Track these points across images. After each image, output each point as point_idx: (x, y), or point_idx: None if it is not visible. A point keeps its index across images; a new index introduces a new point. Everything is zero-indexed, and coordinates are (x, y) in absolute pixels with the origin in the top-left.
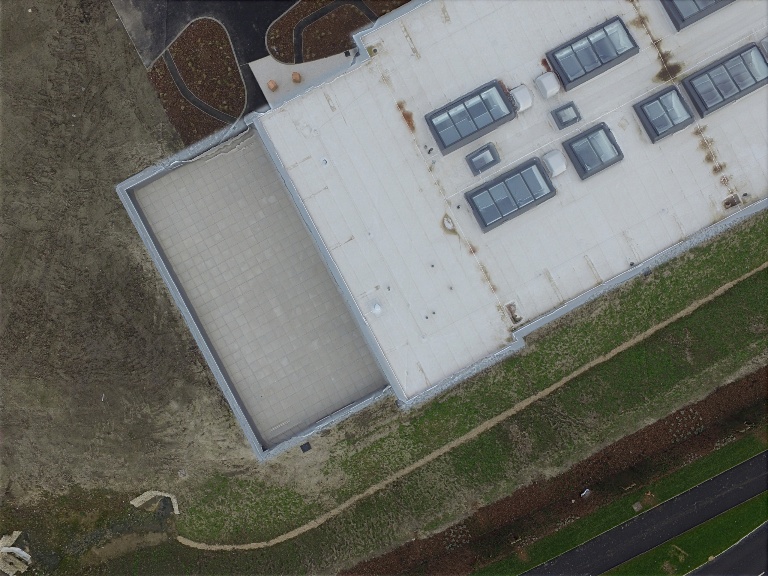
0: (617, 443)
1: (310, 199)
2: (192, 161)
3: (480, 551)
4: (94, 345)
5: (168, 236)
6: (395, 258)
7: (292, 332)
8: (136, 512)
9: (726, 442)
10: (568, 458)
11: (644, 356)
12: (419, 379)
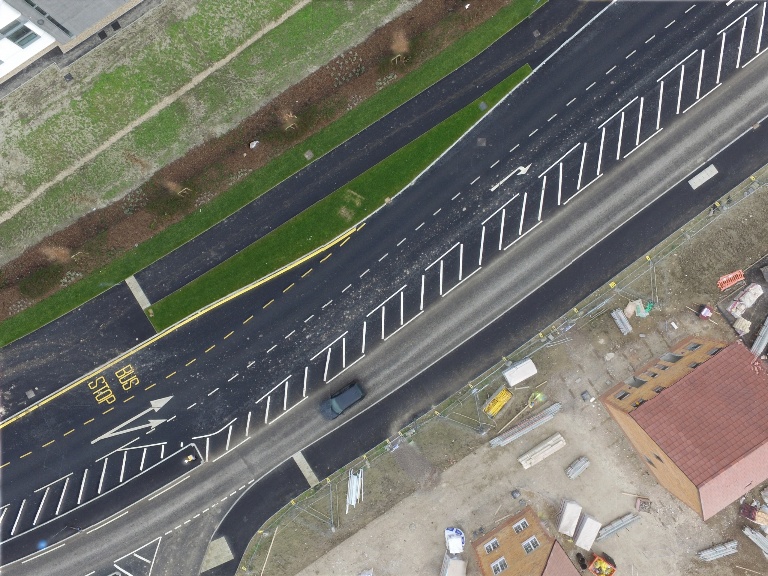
0: (283, 94)
1: None
2: None
3: (157, 212)
4: None
5: None
6: None
7: None
8: None
9: (388, 80)
10: (237, 114)
11: (311, 14)
12: None
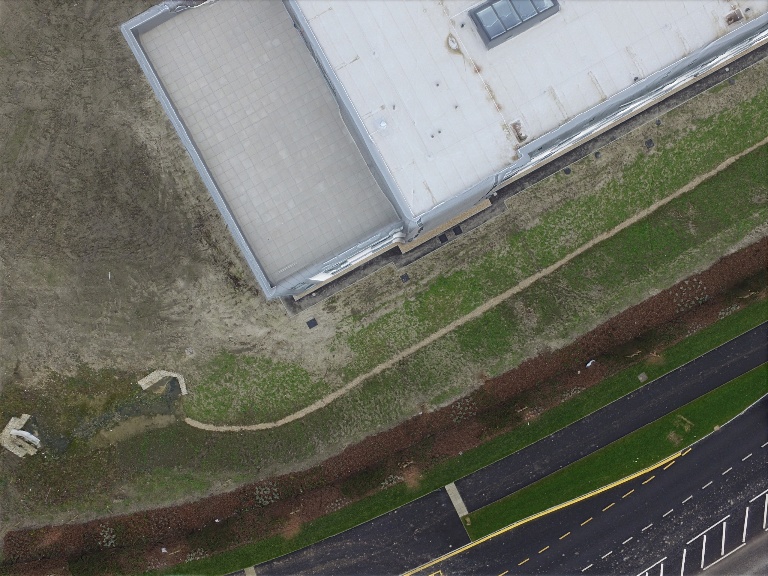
0: (622, 314)
1: (315, 20)
2: (196, 7)
3: (487, 423)
4: (100, 224)
5: (173, 80)
6: (400, 77)
7: (298, 174)
8: (144, 395)
9: (730, 311)
10: (573, 330)
11: (648, 231)
12: (425, 198)
